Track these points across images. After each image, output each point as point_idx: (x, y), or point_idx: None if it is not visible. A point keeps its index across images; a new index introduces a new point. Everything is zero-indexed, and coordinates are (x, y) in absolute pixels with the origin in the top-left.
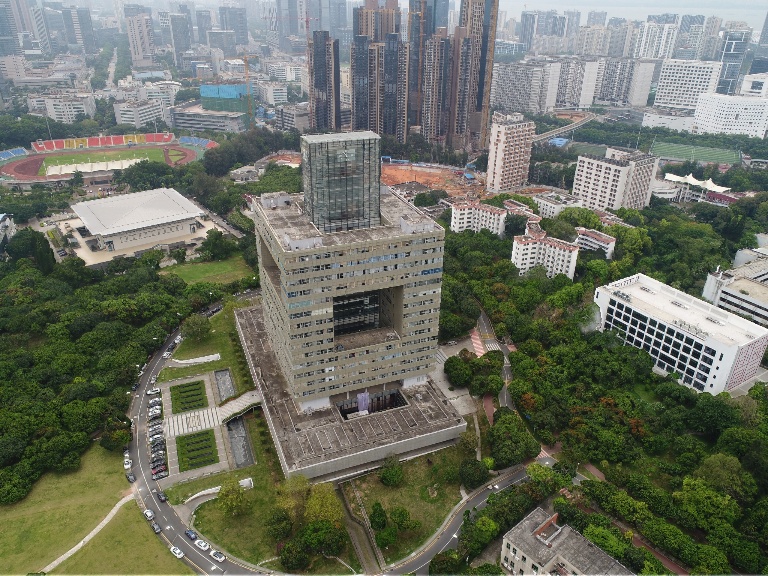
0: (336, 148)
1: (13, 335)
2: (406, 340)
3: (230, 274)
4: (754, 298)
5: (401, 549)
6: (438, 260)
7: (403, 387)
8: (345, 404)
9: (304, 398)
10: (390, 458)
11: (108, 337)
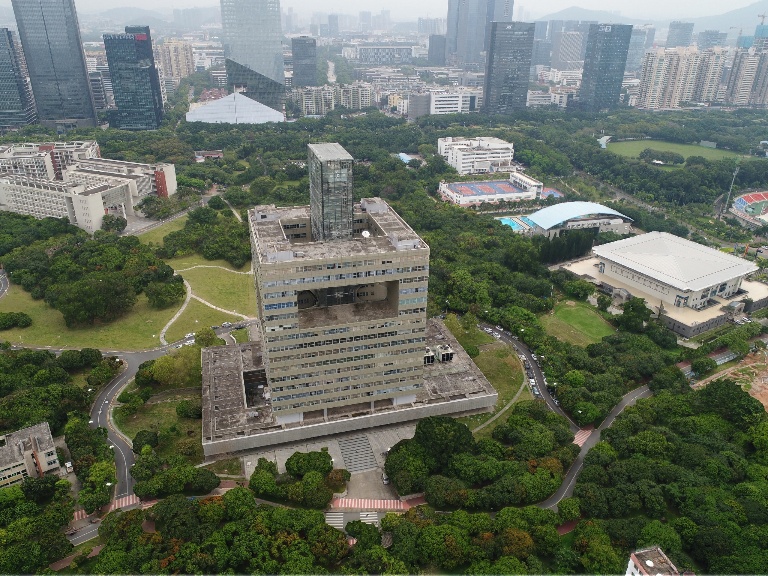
0: None
1: None
2: None
3: (583, 338)
4: None
5: None
6: None
7: None
8: None
9: None
10: (196, 401)
11: None
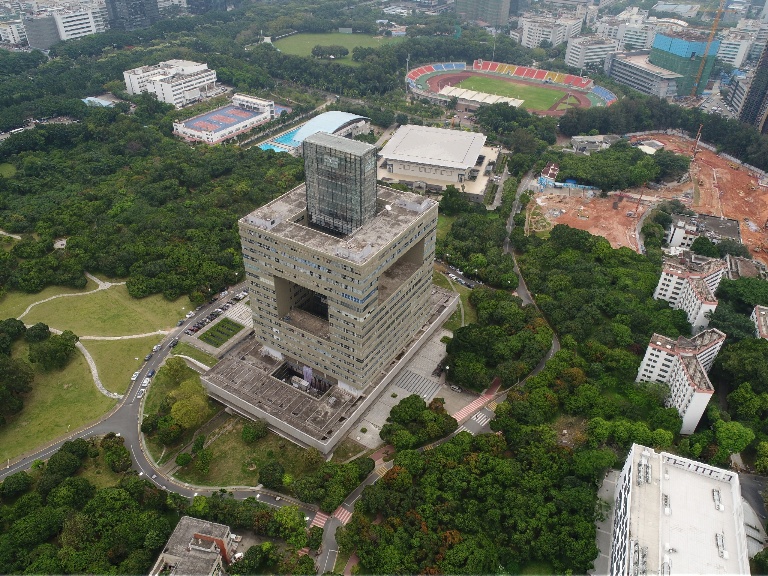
0: (323, 152)
1: (244, 204)
2: (334, 346)
3: None
4: None
5: (189, 476)
6: (357, 291)
7: (338, 385)
8: (295, 366)
9: (261, 340)
10: (258, 421)
11: None
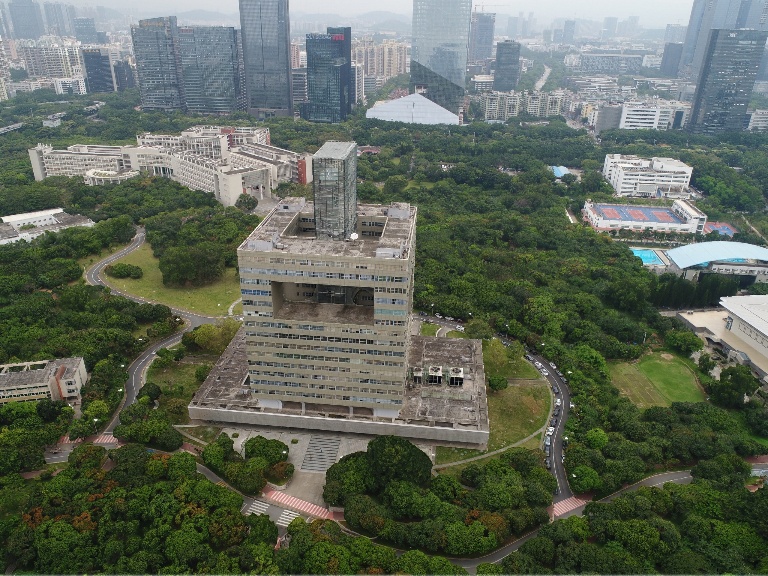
0: None
1: (499, 265)
2: None
3: (657, 398)
4: None
5: None
6: None
7: None
8: None
9: None
10: None
11: (488, 299)
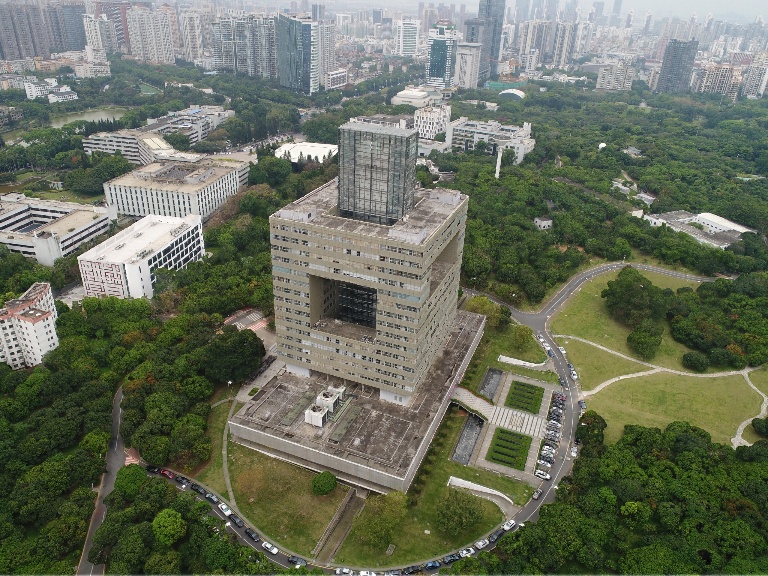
0: None
1: None
2: None
3: None
4: (78, 228)
5: None
6: None
7: None
8: None
9: None
10: None
11: None
